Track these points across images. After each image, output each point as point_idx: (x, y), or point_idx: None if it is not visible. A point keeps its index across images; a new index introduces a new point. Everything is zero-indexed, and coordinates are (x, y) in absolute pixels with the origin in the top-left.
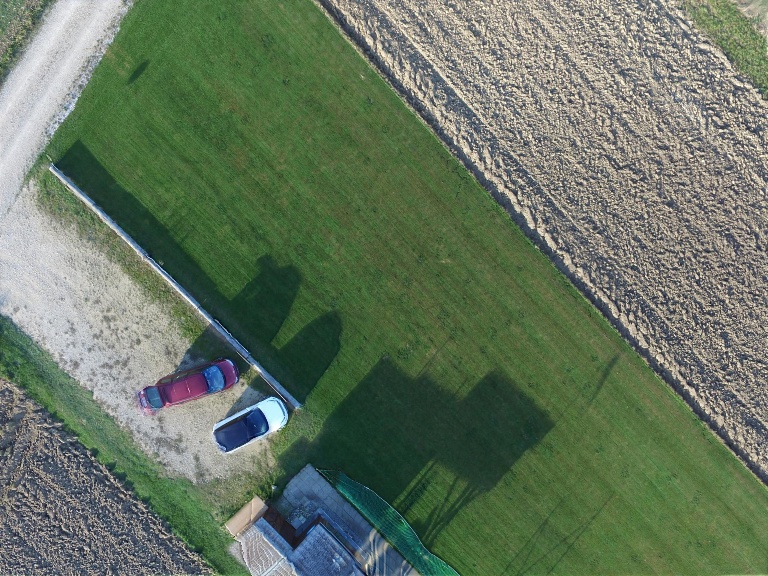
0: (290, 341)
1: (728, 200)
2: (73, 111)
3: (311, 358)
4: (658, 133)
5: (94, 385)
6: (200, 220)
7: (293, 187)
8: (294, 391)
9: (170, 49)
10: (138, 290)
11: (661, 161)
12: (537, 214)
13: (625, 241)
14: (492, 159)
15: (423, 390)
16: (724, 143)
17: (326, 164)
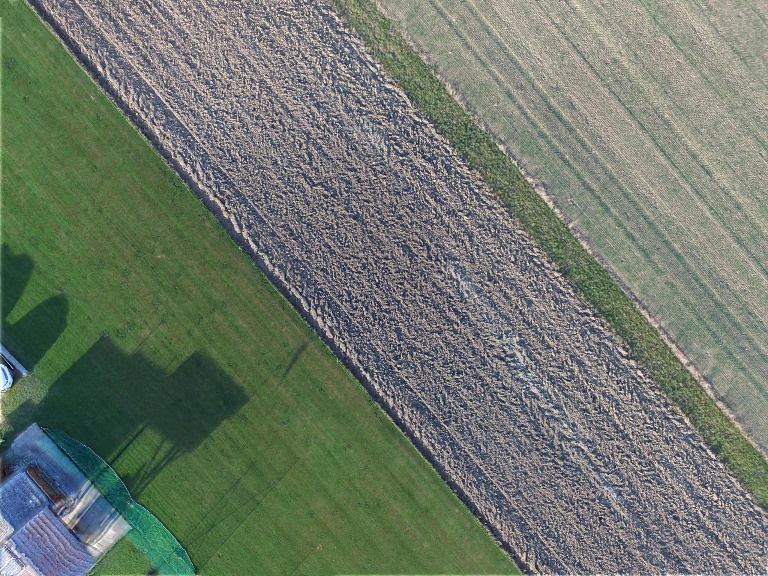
0: (23, 318)
1: (406, 216)
2: None
3: (40, 333)
4: (347, 157)
5: None
6: None
7: (30, 187)
8: (23, 360)
9: None
10: None
11: (350, 181)
12: (242, 220)
13: (317, 247)
14: (204, 172)
15: (137, 365)
16: (403, 168)
17: (59, 169)
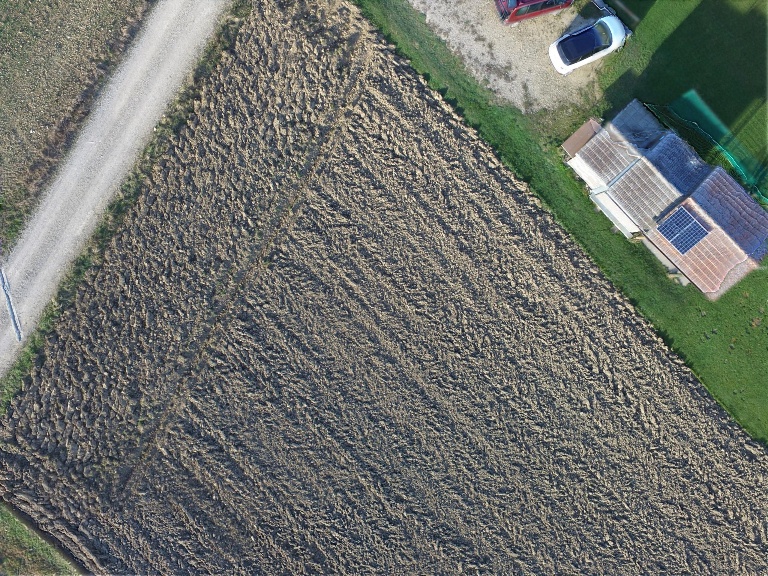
0: None
1: None
2: None
3: None
4: None
5: (427, 8)
6: None
7: None
8: (625, 19)
9: None
10: None
11: None
12: None
13: None
14: None
15: (756, 23)
16: None
17: None
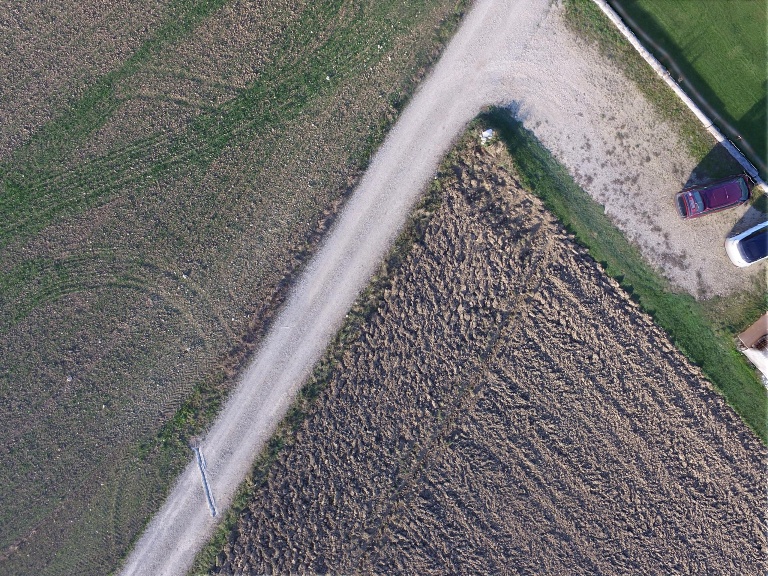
0: None
1: None
2: None
3: None
4: None
5: (606, 200)
6: (716, 39)
7: None
8: None
9: None
10: (652, 108)
11: None
12: None
13: None
14: None
15: None
16: None
17: None
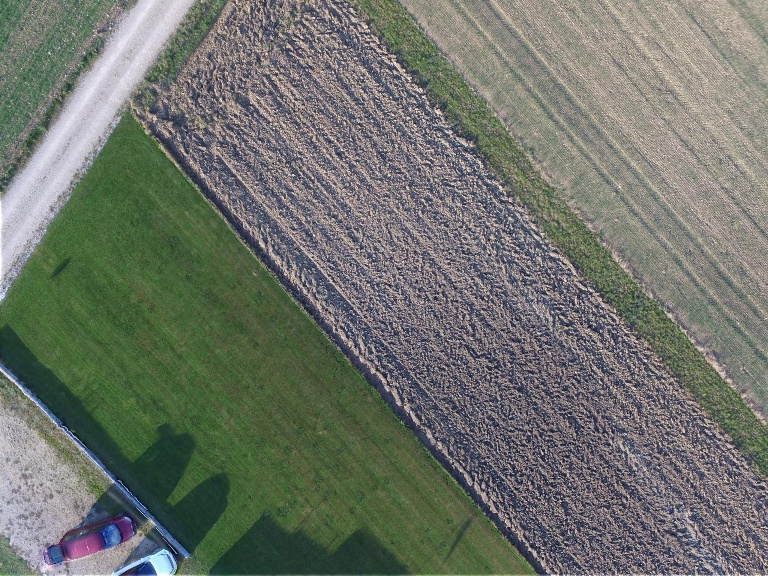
0: (184, 498)
1: (571, 387)
2: (3, 299)
3: (201, 514)
4: (511, 328)
5: (11, 533)
6: (109, 394)
7: (191, 366)
8: (185, 542)
9: (89, 248)
10: (53, 452)
11: (514, 351)
12: (404, 394)
13: (480, 420)
14: (366, 346)
15: (299, 544)
16: (569, 338)
17: (221, 347)
